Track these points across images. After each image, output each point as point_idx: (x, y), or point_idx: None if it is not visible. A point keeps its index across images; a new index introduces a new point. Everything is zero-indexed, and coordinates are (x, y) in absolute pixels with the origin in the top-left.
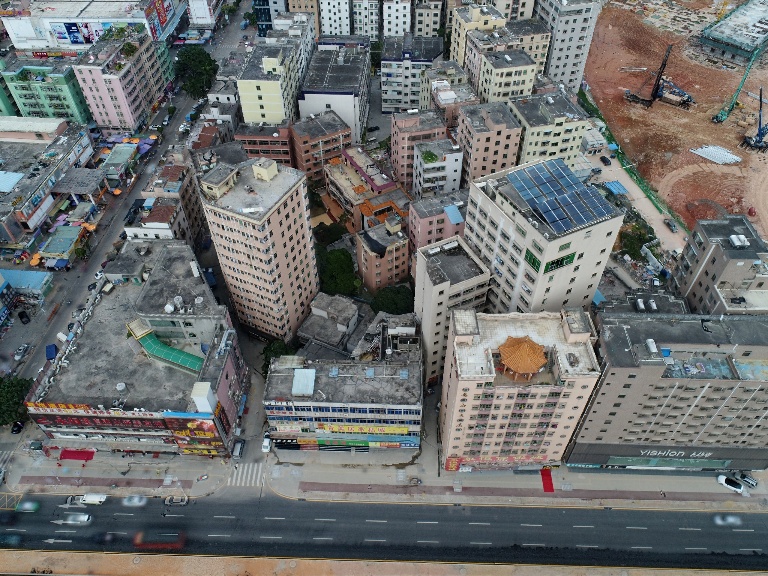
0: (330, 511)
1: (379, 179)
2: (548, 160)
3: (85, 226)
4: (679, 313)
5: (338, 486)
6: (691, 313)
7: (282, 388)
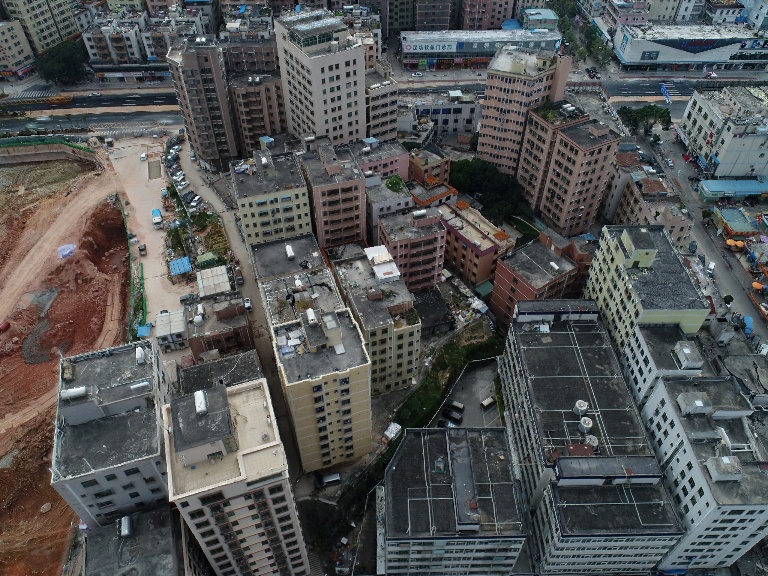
0: None
1: (446, 213)
2: (312, 28)
3: (738, 242)
4: (235, 82)
5: None
6: (229, 78)
7: None
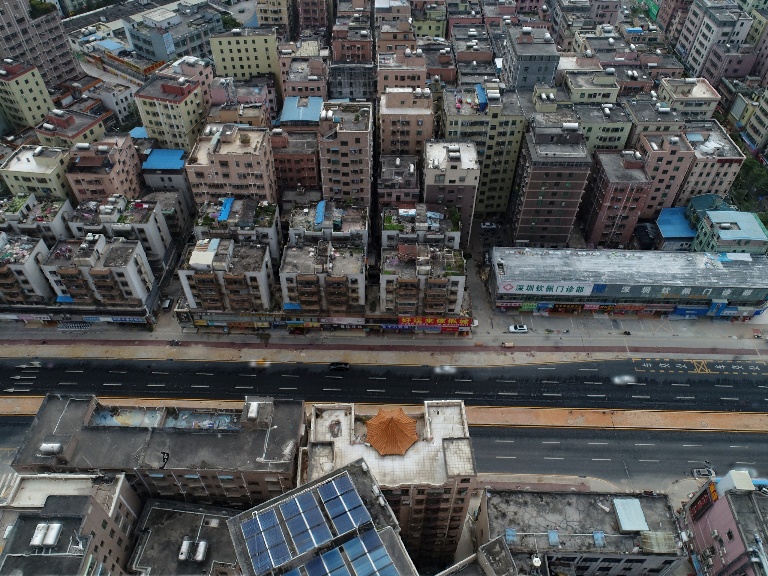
0: (552, 466)
1: None
2: None
3: None
4: (152, 545)
5: (551, 489)
6: (139, 537)
7: (654, 515)
